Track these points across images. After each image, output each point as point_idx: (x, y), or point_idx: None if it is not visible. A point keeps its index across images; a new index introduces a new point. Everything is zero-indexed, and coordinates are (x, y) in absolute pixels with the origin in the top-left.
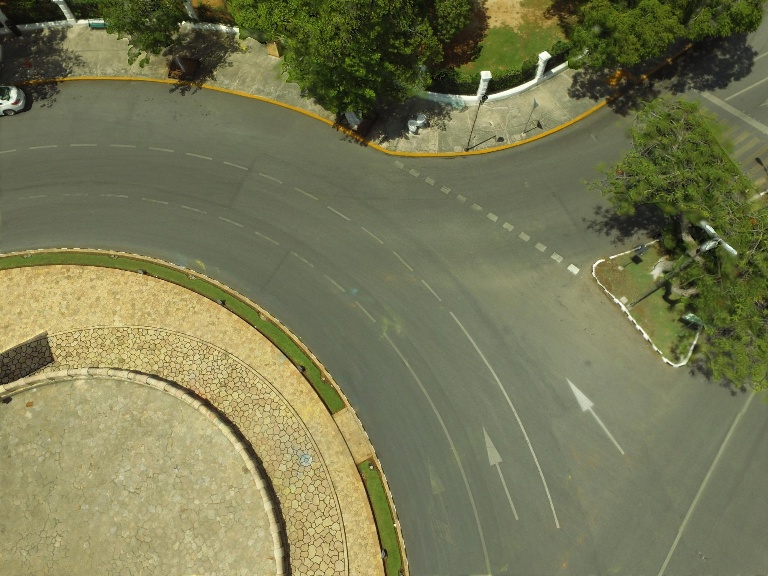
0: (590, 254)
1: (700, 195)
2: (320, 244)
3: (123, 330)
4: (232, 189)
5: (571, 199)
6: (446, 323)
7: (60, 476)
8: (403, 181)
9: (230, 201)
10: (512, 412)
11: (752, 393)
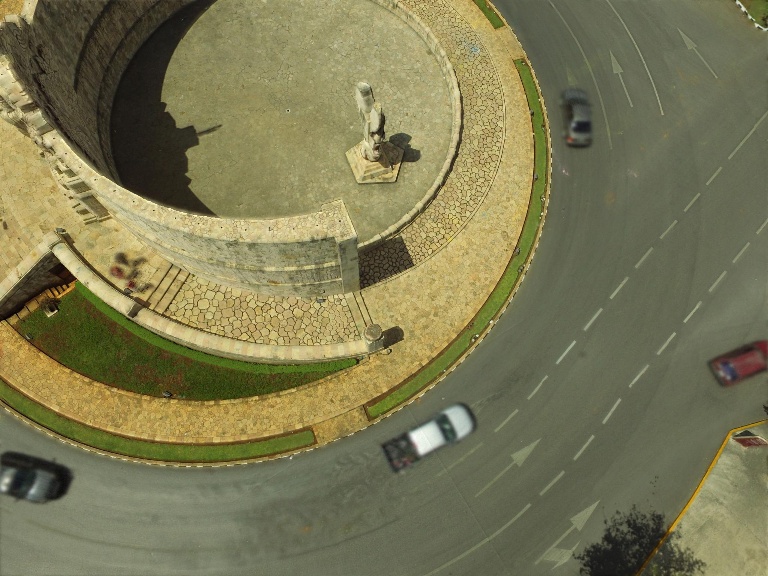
0: None
1: None
2: None
3: None
4: None
5: None
6: None
7: (290, 40)
8: None
9: None
10: (633, 44)
11: None
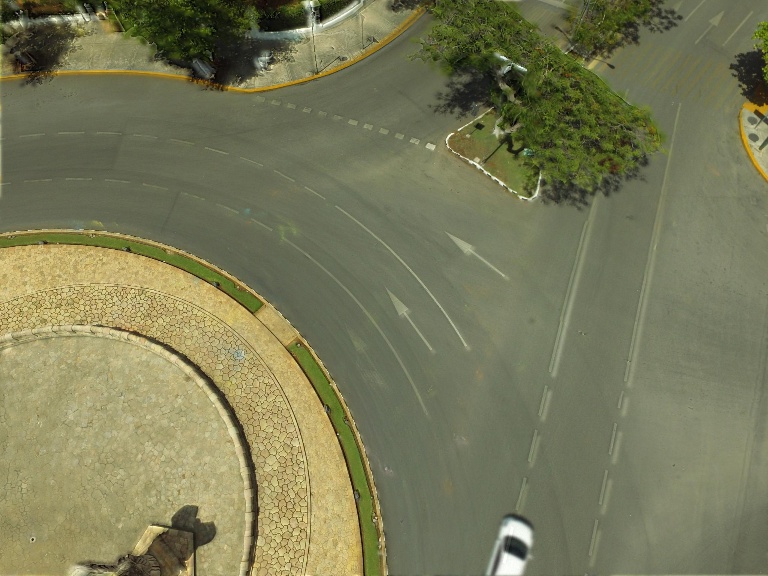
0: (441, 131)
1: (496, 41)
2: (206, 180)
3: (37, 295)
4: (111, 153)
5: (416, 93)
6: (334, 215)
7: (10, 434)
8: (268, 111)
9: (112, 164)
10: (407, 270)
11: (592, 204)
